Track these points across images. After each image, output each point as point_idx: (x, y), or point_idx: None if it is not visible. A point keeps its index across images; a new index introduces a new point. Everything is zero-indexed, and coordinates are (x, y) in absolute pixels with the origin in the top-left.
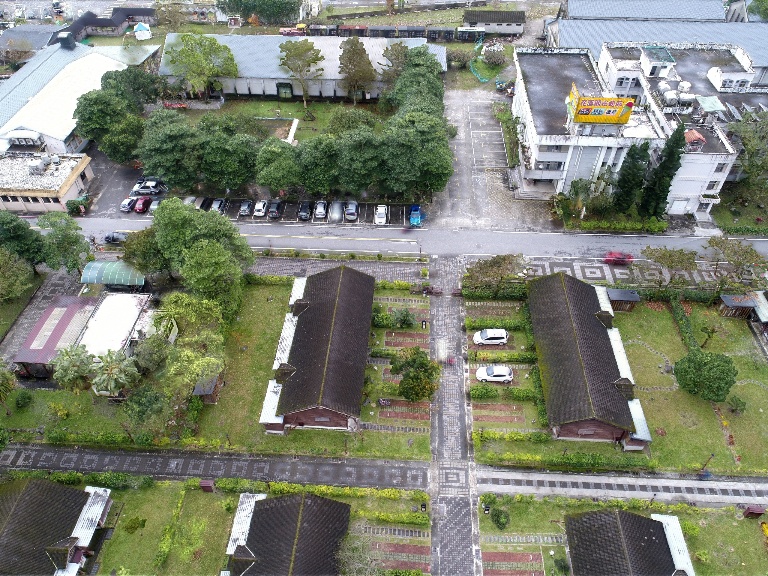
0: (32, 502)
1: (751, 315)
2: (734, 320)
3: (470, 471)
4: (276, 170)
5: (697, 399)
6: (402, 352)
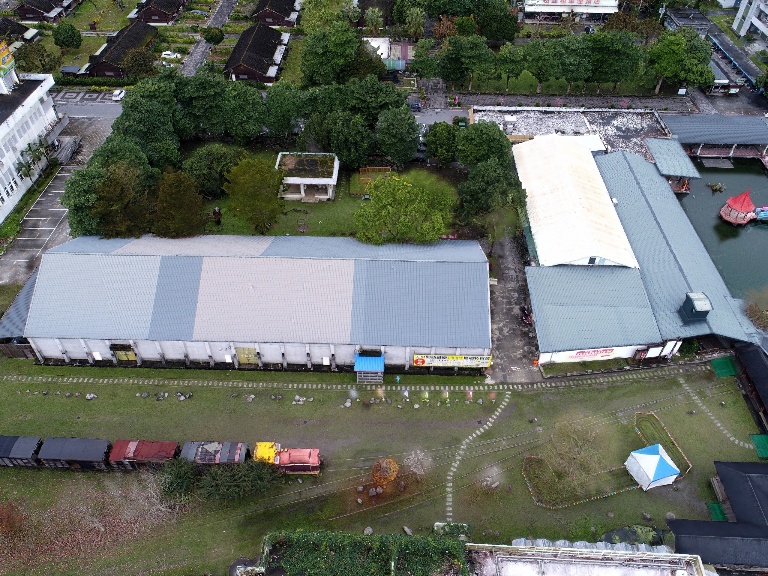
0: None
1: None
2: None
3: None
4: None
5: (75, 51)
6: (216, 30)
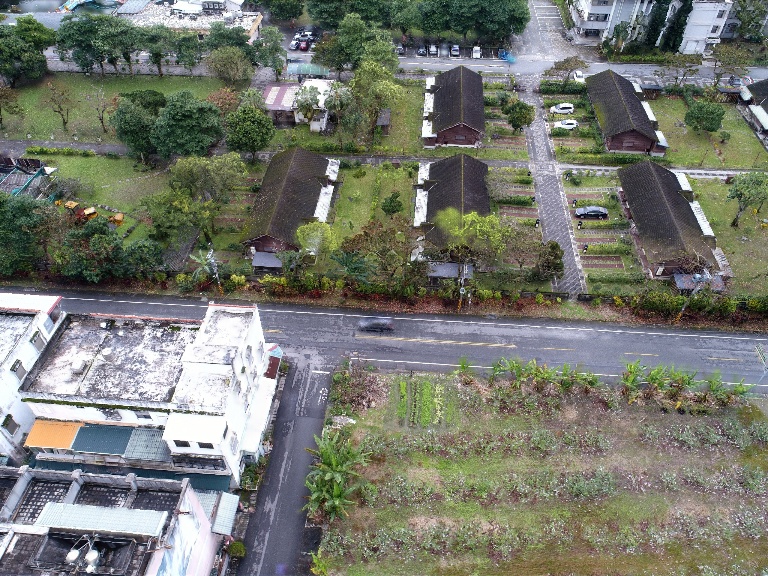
0: (302, 156)
1: (738, 101)
2: (726, 104)
3: (555, 165)
4: (407, 13)
5: (699, 137)
6: (510, 100)
